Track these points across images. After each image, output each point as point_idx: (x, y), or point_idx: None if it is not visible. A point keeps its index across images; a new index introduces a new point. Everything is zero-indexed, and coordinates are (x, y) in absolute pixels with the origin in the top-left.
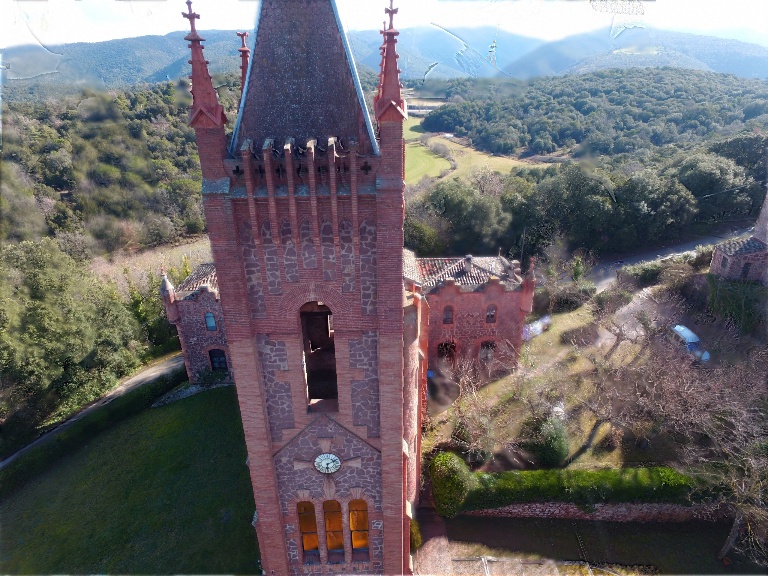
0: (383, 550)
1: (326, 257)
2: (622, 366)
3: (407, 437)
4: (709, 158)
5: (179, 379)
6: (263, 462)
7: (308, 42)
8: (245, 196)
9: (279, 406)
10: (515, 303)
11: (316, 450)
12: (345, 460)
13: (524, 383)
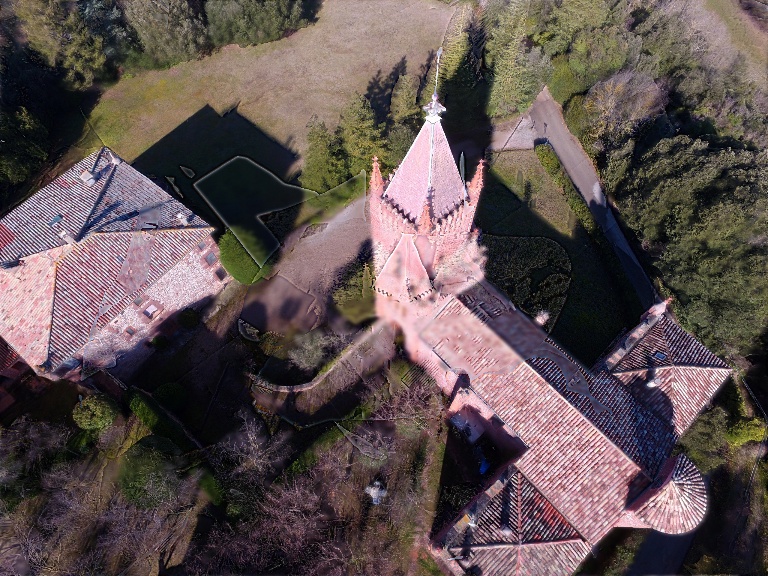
0: None
1: None
2: None
3: None
4: None
5: None
6: None
7: None
8: None
9: None
10: None
11: None
12: None
13: (415, 523)
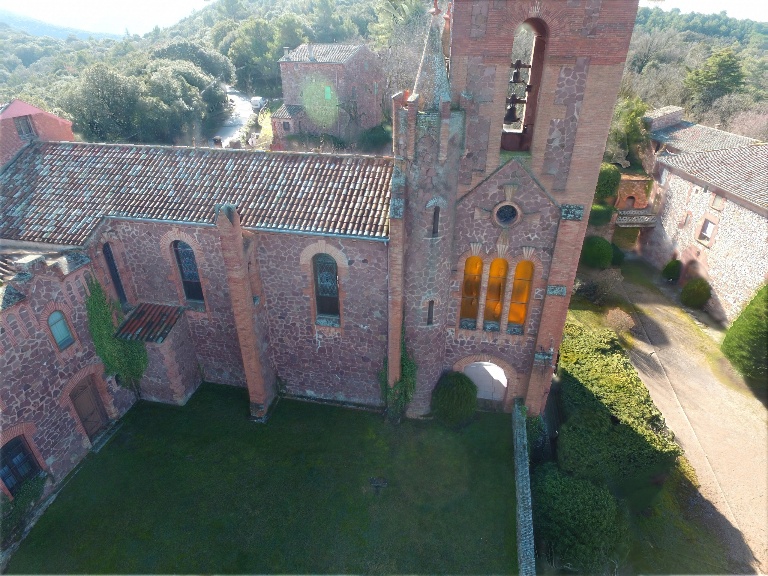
0: None
1: None
2: None
3: None
4: (170, 62)
5: None
6: None
7: None
8: None
9: None
10: None
11: None
12: None
13: None
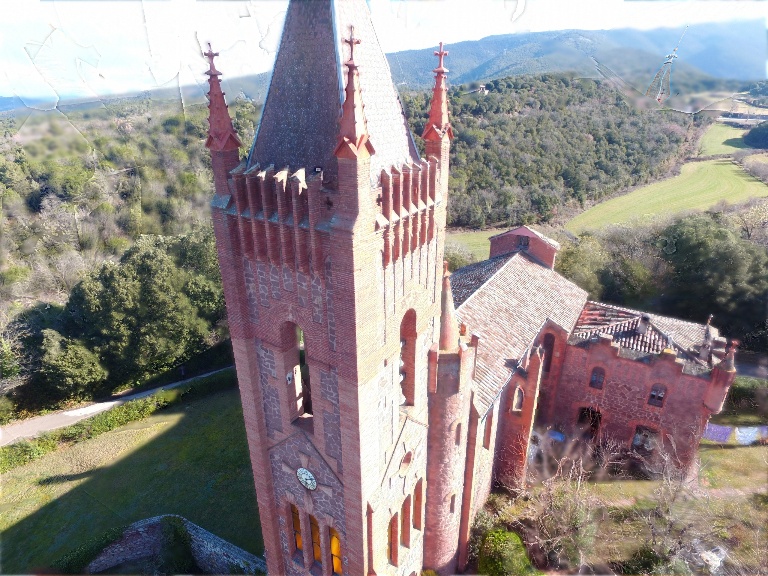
0: None
1: (300, 283)
2: None
3: (440, 492)
4: None
5: None
6: (257, 451)
7: (311, 73)
8: (236, 214)
9: (272, 407)
10: (696, 393)
11: (298, 461)
12: (320, 483)
13: None
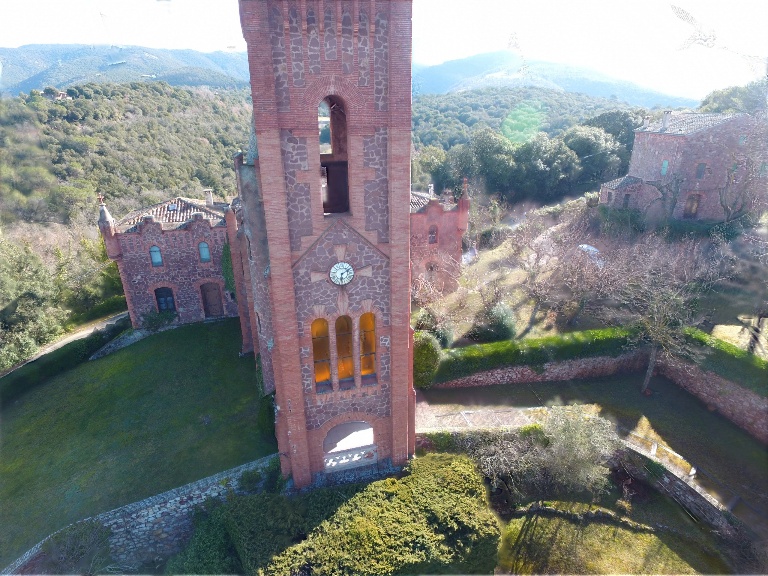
0: (390, 369)
1: (345, 49)
2: (548, 265)
3: None
4: (584, 129)
5: (116, 334)
6: (284, 270)
7: None
8: None
9: (298, 211)
10: (453, 223)
11: (331, 259)
12: (358, 269)
13: None
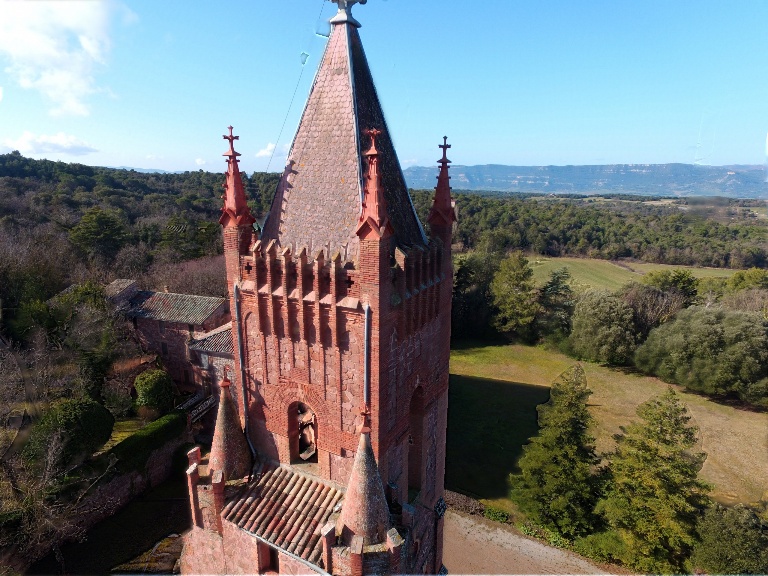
0: None
1: None
2: None
3: None
4: None
5: None
6: None
7: None
8: None
9: None
10: None
11: None
12: None
13: None
